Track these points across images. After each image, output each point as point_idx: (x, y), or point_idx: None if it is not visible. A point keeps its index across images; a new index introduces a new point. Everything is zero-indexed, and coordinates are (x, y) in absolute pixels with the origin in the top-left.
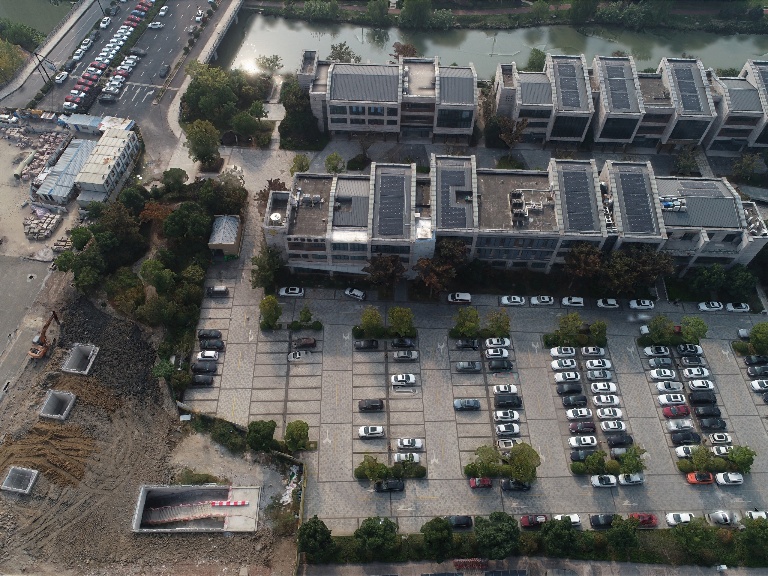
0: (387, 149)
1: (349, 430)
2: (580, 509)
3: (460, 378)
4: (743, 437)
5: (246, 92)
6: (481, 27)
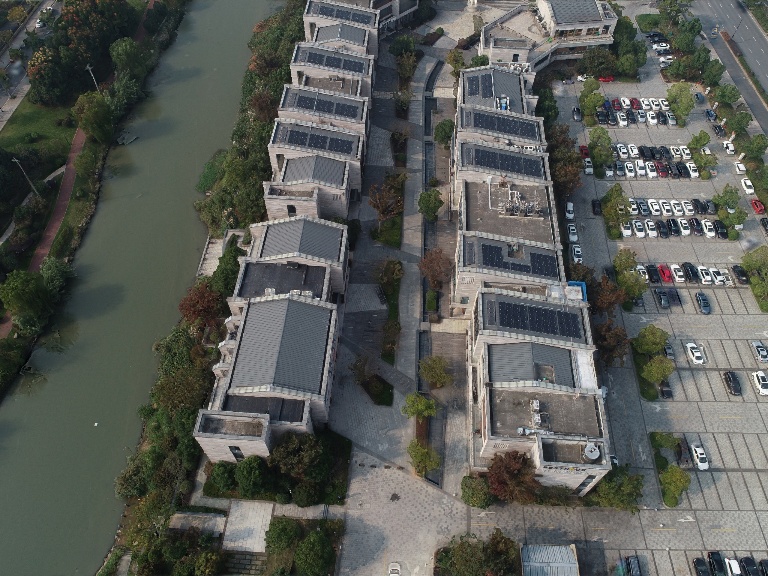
0: (351, 356)
1: (765, 405)
2: (764, 241)
3: (675, 307)
4: (668, 141)
5: (213, 567)
6: (82, 235)
